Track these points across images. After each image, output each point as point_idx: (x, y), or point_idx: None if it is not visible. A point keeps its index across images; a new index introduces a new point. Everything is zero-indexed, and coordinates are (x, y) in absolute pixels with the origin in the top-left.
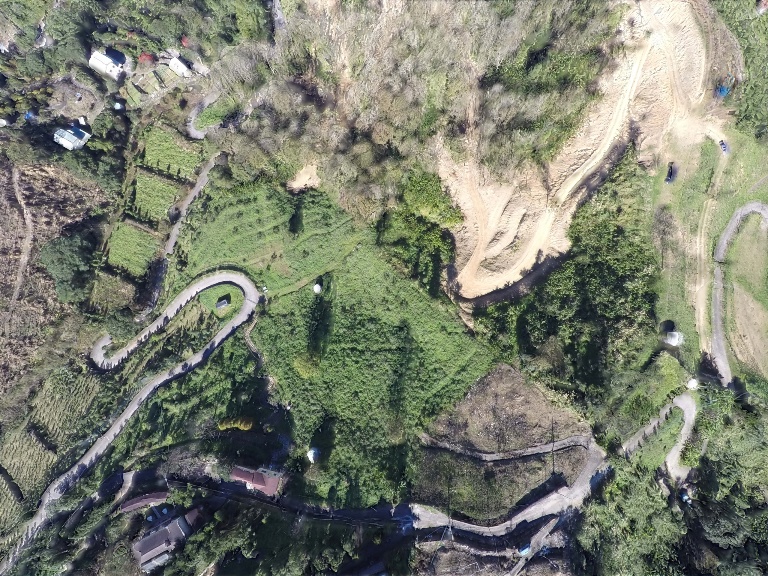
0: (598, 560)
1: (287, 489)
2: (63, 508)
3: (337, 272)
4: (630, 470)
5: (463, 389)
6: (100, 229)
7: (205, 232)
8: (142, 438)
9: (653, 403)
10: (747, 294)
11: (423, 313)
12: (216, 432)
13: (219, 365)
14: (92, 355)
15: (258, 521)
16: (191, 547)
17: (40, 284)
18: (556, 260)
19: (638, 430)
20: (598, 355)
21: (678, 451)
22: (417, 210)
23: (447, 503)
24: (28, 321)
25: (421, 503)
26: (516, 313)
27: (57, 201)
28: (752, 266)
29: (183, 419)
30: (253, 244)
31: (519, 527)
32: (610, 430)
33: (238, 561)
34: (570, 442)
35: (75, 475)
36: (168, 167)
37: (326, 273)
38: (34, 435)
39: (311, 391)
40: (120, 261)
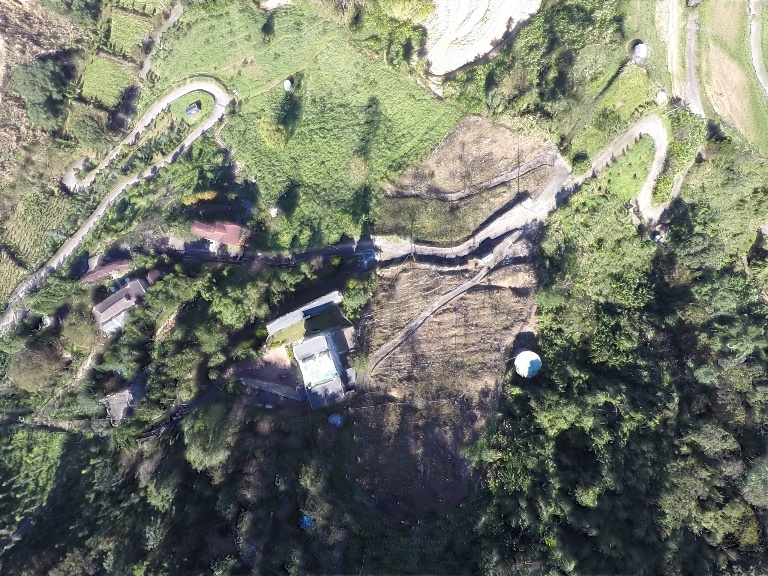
0: (562, 263)
1: (249, 242)
2: (28, 300)
3: (308, 70)
4: (598, 193)
5: (430, 146)
6: (74, 64)
7: (177, 48)
8: (108, 227)
9: (620, 116)
10: (723, 51)
11: (392, 87)
12: (181, 209)
13: (187, 161)
14: (64, 181)
15: (219, 272)
16: (151, 296)
17: (13, 113)
18: (526, 21)
19: (605, 143)
20: (565, 81)
21: (650, 189)
22: (389, 8)
23: (410, 231)
24: (0, 147)
25: (383, 235)
26: (485, 71)
27: (31, 33)
28: (728, 25)
29: (150, 207)
30: (224, 52)
31: (482, 244)
32: (576, 142)
33: (198, 308)
34: (536, 164)
35: (43, 277)
36: (144, 7)
37: (297, 72)
38: (4, 253)
39: (278, 166)
40: (94, 93)
